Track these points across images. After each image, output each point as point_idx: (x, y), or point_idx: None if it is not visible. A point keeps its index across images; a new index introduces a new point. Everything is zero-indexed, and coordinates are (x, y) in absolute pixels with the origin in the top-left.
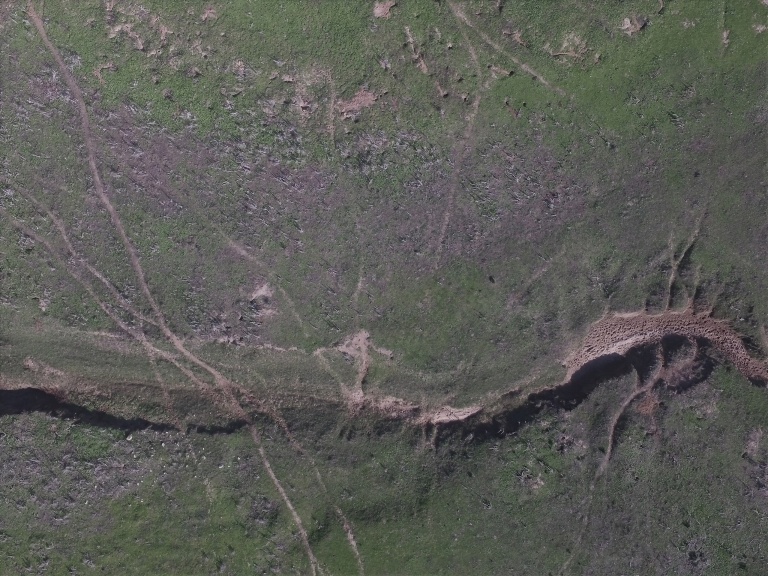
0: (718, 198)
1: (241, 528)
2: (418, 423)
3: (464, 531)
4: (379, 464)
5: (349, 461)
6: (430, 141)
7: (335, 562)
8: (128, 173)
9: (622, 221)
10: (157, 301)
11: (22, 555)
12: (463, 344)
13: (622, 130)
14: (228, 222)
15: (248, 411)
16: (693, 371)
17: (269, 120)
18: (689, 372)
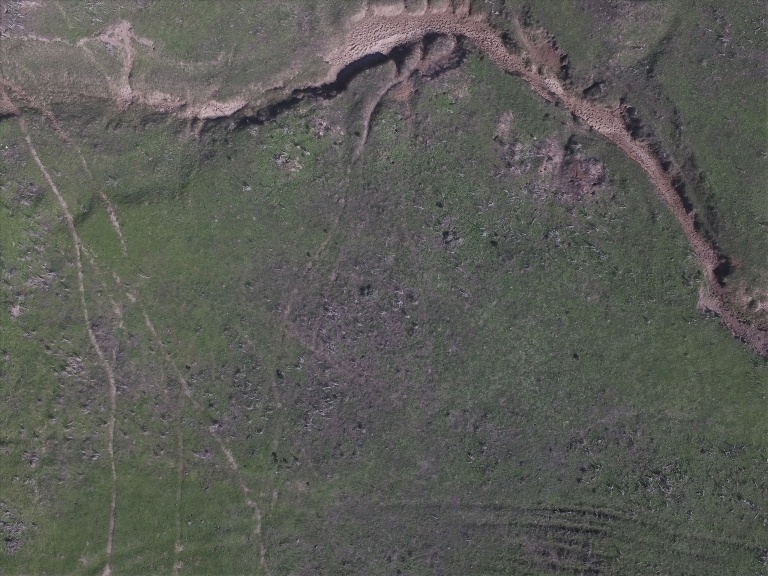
0: None
1: (6, 209)
2: (184, 117)
3: (224, 213)
4: (144, 153)
5: (114, 150)
6: None
7: (99, 243)
8: None
9: None
10: None
11: None
12: (223, 35)
13: None
14: None
15: (18, 106)
16: (449, 62)
17: None
18: (445, 63)
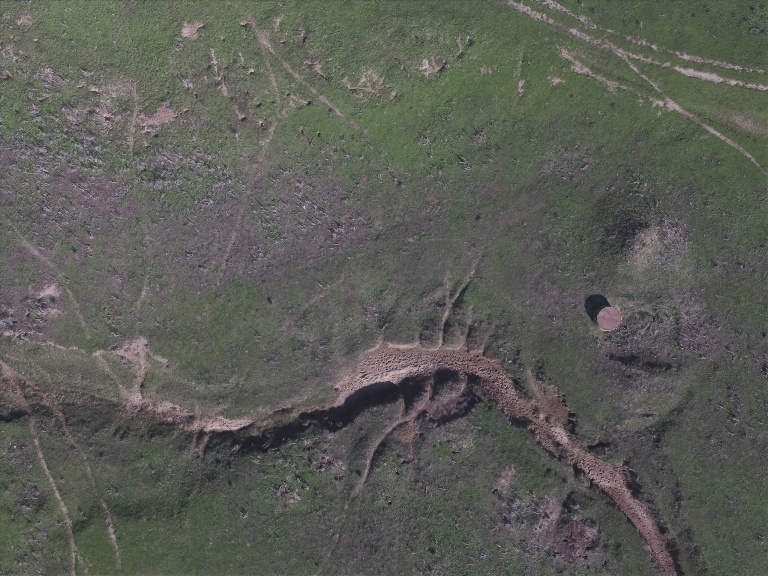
0: (496, 242)
1: (8, 512)
2: (191, 430)
3: (220, 536)
4: (148, 465)
5: (119, 459)
6: (224, 161)
7: (95, 553)
8: None
9: (401, 256)
10: None
11: None
12: (237, 359)
13: (411, 168)
14: (24, 222)
15: (31, 403)
16: (457, 406)
17: (72, 127)
18: (453, 407)
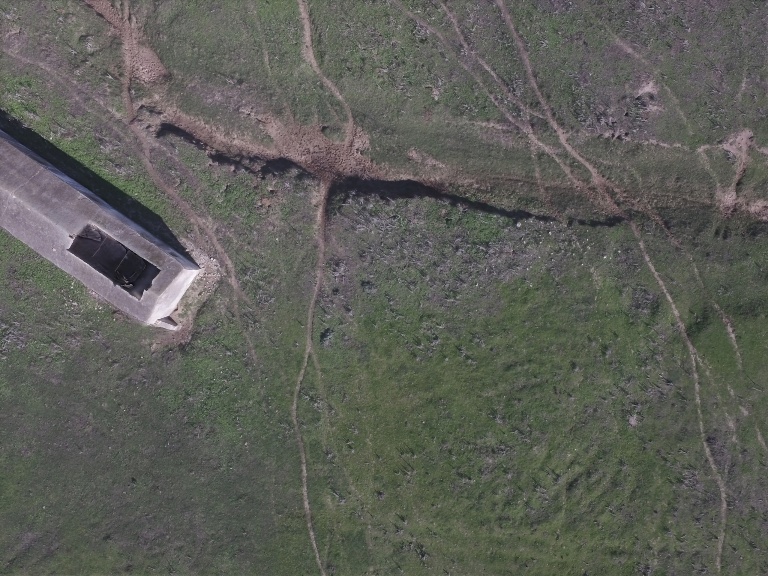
0: None
1: (625, 316)
2: None
3: None
4: (754, 263)
5: (726, 259)
6: None
7: (714, 354)
8: None
9: None
10: (545, 95)
11: (413, 334)
12: None
13: None
14: (616, 20)
15: (624, 208)
16: None
17: None
18: None
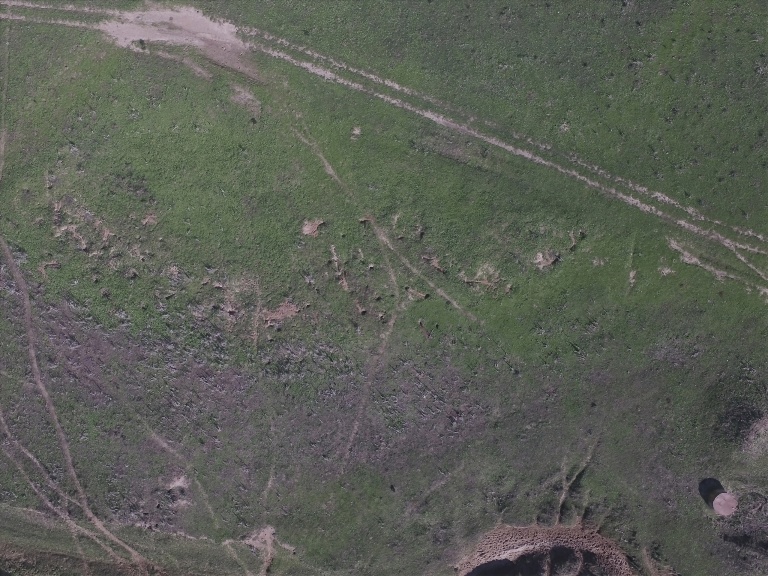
0: (611, 429)
1: None
2: None
3: None
4: None
5: None
6: (346, 354)
7: None
8: (64, 363)
9: (519, 443)
10: (82, 484)
11: None
12: (361, 546)
13: (527, 357)
14: (153, 416)
15: None
16: None
17: (198, 323)
18: None
